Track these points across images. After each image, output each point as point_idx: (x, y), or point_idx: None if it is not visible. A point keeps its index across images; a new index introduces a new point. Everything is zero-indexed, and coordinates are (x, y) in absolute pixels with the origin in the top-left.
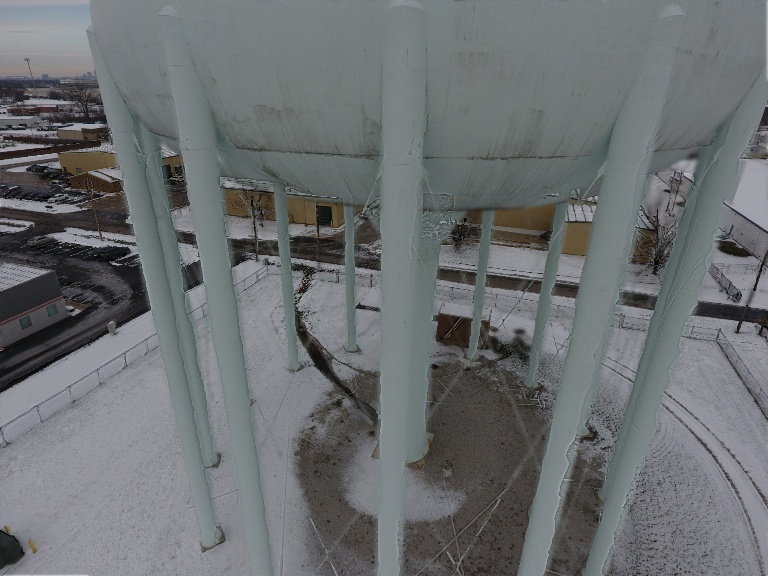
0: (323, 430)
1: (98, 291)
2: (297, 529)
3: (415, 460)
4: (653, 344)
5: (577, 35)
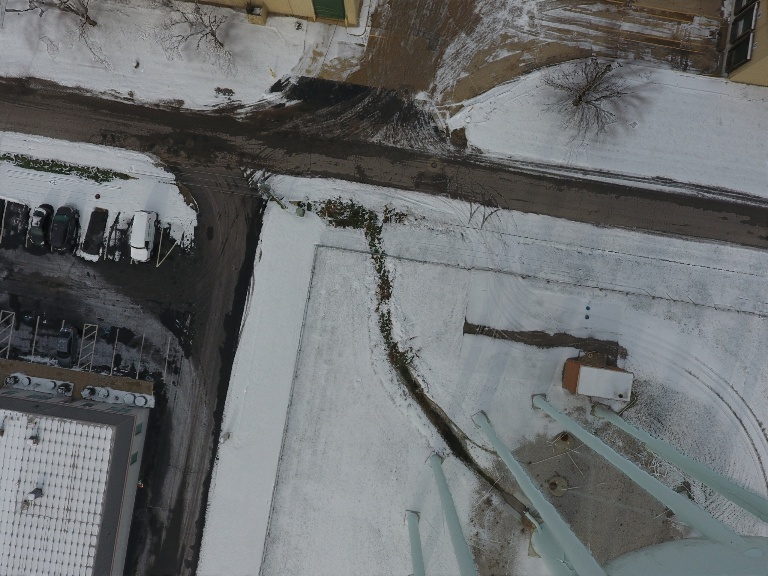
0: (486, 536)
1: (132, 344)
2: None
3: None
4: None
5: None
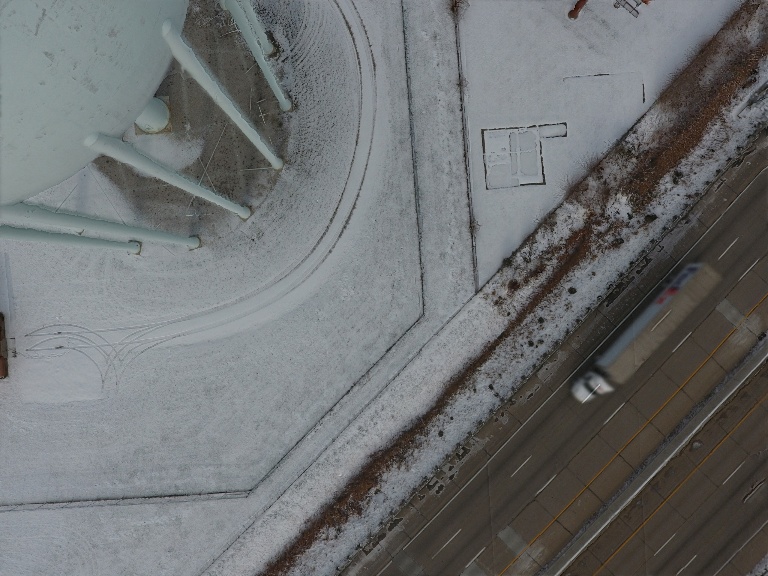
0: None
1: None
2: (120, 202)
3: (164, 126)
4: (254, 53)
5: (55, 172)
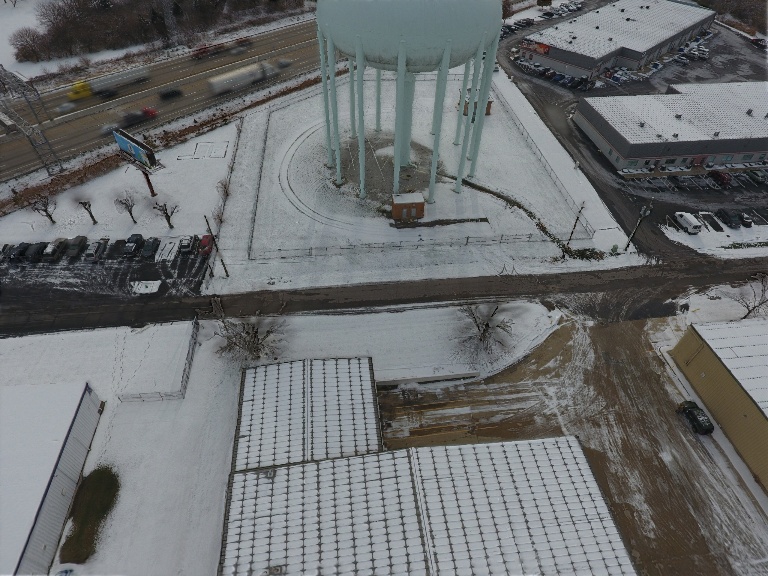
0: None
1: (649, 188)
2: None
3: None
4: None
5: None
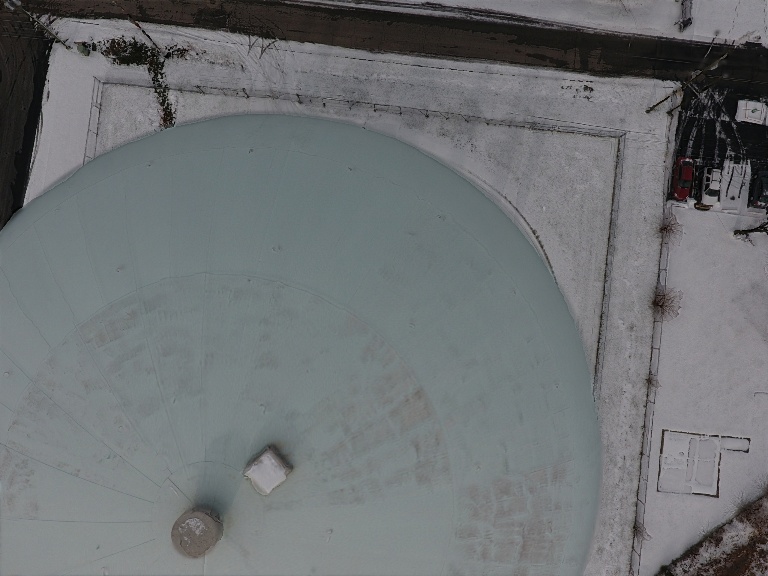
0: None
1: None
2: None
3: None
4: None
5: None
